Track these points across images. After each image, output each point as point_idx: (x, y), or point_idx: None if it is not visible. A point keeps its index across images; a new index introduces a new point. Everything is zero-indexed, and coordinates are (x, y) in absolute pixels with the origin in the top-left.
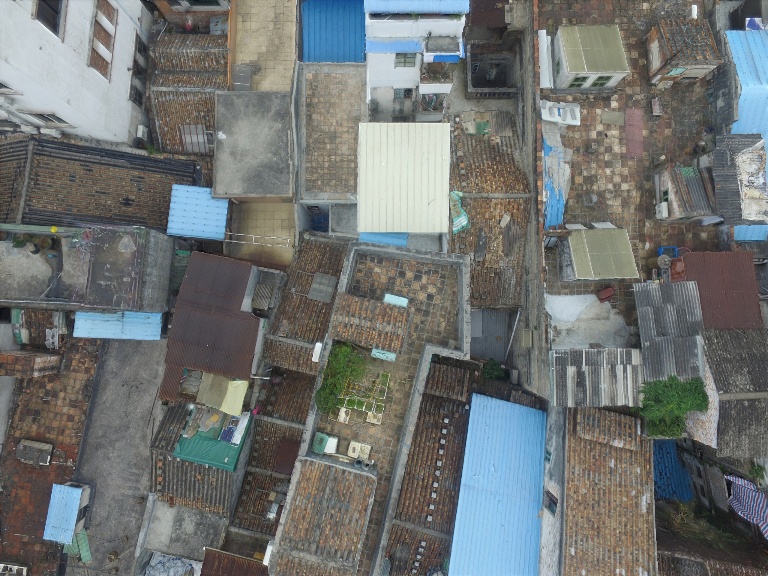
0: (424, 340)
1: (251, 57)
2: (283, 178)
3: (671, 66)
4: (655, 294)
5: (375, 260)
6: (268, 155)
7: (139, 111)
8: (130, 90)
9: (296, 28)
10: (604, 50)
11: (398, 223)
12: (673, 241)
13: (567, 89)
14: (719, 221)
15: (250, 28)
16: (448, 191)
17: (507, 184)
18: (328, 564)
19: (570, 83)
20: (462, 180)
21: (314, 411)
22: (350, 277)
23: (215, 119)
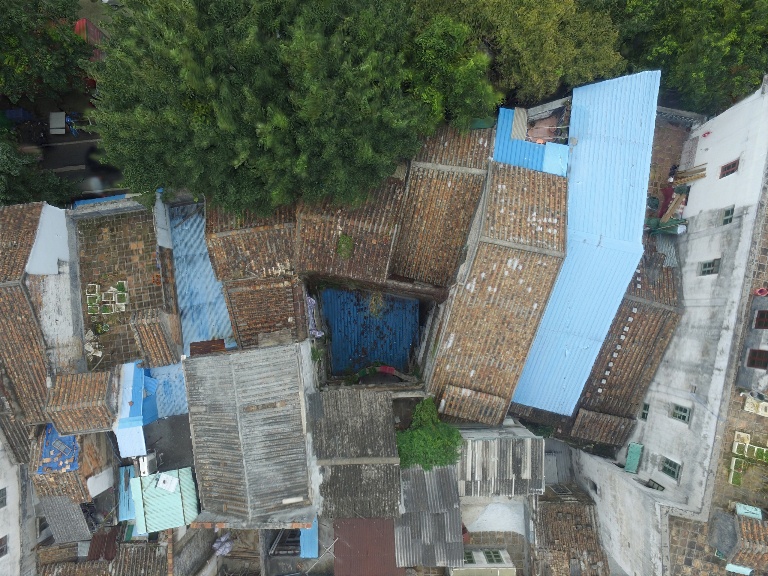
0: None
1: None
2: None
3: None
4: (442, 555)
5: None
6: None
7: None
8: None
9: None
10: None
11: None
12: None
13: None
14: None
15: None
16: None
17: None
18: None
19: None
20: None
21: None
22: None
23: None
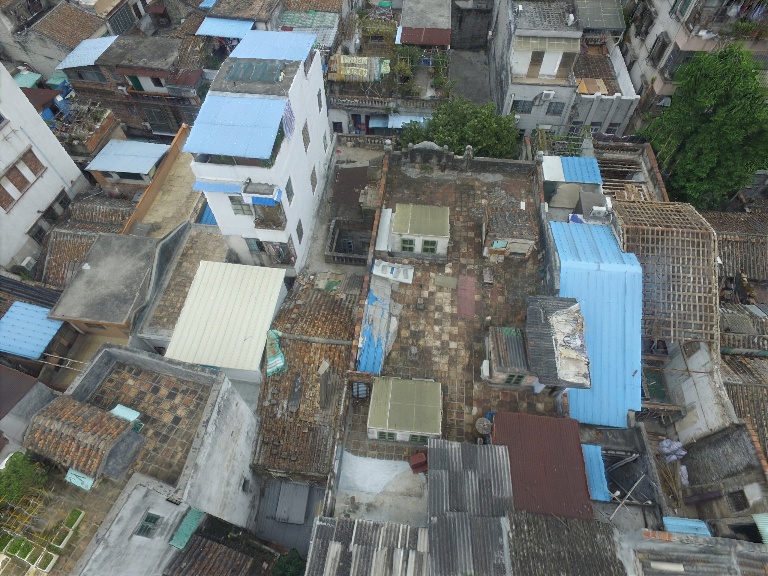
0: (148, 472)
1: (157, 219)
2: (125, 308)
3: (490, 237)
4: (454, 455)
5: (133, 371)
6: (120, 287)
7: (37, 247)
8: (32, 227)
9: (199, 200)
10: (430, 221)
11: (208, 355)
12: (505, 409)
13: (402, 253)
14: (547, 387)
15: (166, 200)
16: (268, 329)
17: (333, 331)
18: None
19: (401, 246)
20: (289, 323)
21: None
22: (96, 385)
23: (87, 253)
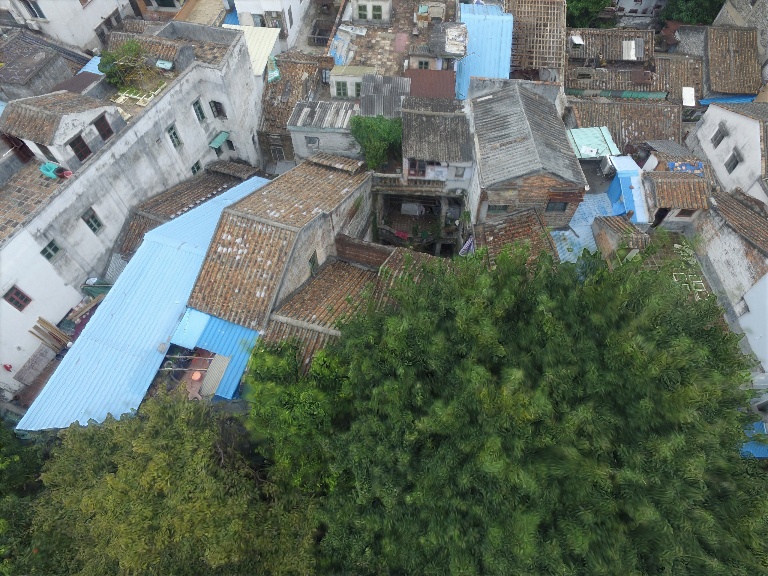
0: None
1: None
2: None
3: (416, 2)
4: (378, 79)
5: (187, 40)
6: None
7: (100, 44)
8: (98, 27)
9: (217, 19)
10: None
11: None
12: None
13: (359, 21)
14: None
15: None
16: None
17: None
18: (44, 112)
19: (358, 13)
20: None
21: (98, 81)
22: None
23: None
